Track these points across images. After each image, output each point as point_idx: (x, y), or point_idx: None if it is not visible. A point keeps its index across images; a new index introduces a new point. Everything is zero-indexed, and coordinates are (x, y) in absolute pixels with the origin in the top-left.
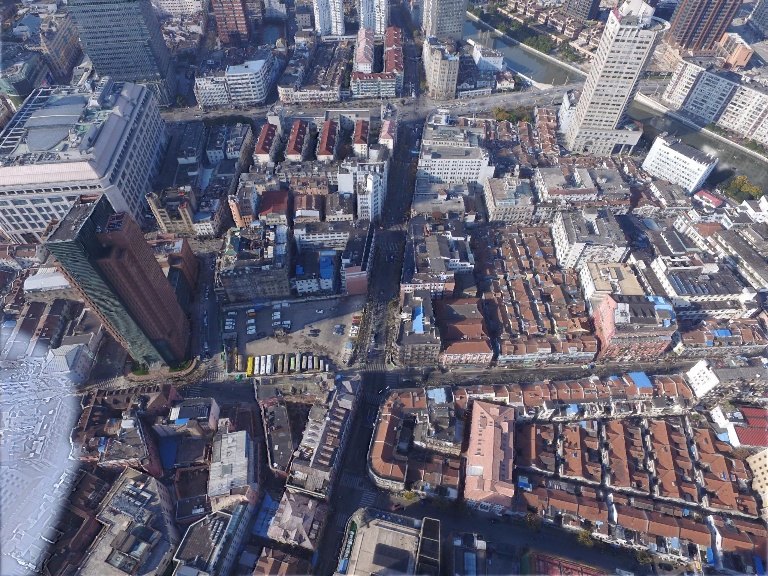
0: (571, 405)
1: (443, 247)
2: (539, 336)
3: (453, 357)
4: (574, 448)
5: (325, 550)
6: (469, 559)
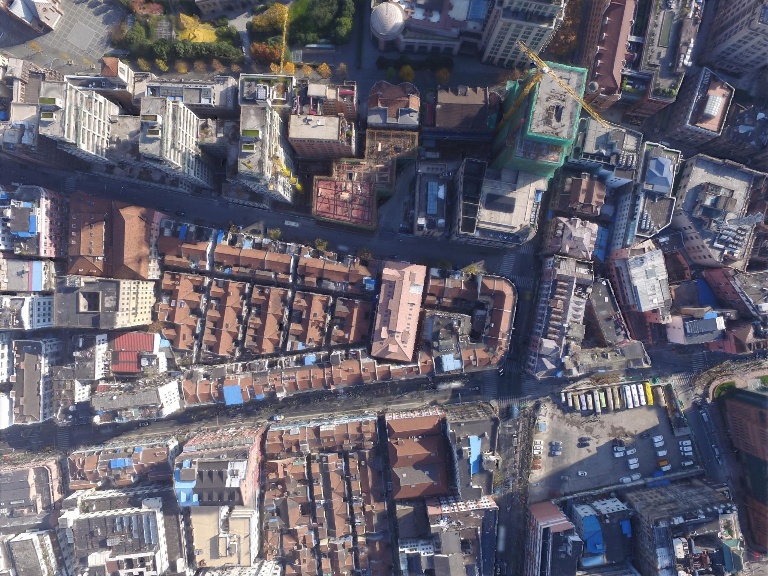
0: (311, 364)
1: (444, 575)
2: (327, 451)
3: (430, 414)
4: (315, 322)
5: (540, 225)
6: (433, 209)
